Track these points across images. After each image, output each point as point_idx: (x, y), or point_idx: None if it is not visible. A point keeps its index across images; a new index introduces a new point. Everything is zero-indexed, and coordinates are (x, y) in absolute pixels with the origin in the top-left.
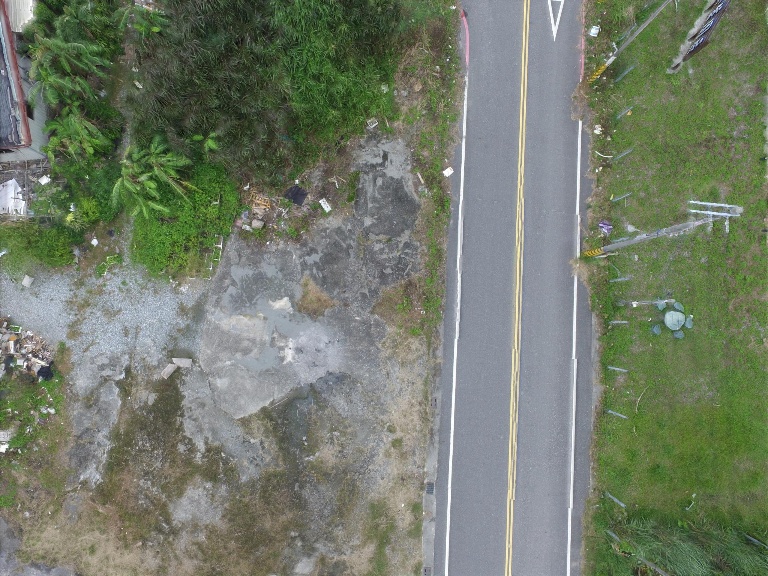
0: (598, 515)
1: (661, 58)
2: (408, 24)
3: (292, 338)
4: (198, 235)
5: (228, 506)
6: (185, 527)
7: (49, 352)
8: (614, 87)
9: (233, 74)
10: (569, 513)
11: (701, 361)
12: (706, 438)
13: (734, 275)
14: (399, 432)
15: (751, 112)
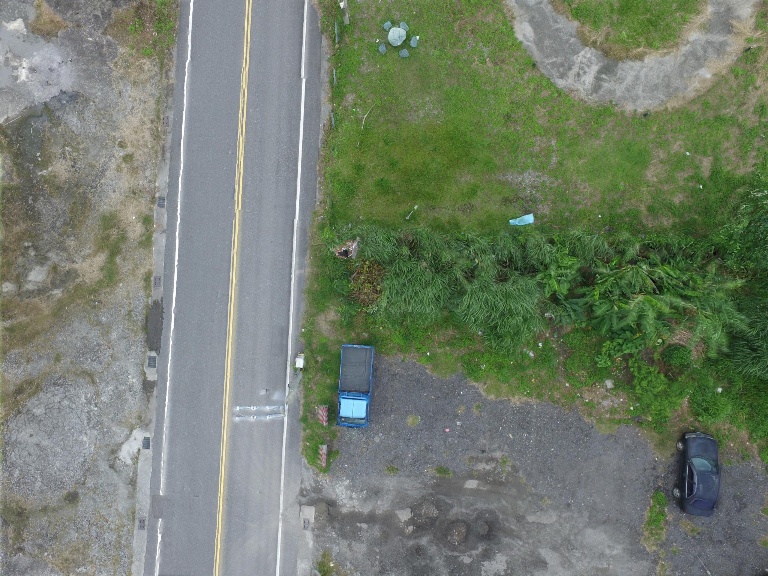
0: (321, 224)
1: None
2: None
3: (26, 58)
4: None
5: None
6: None
7: None
8: None
9: None
10: (295, 224)
11: (426, 80)
12: (429, 153)
13: None
14: (130, 148)
15: None
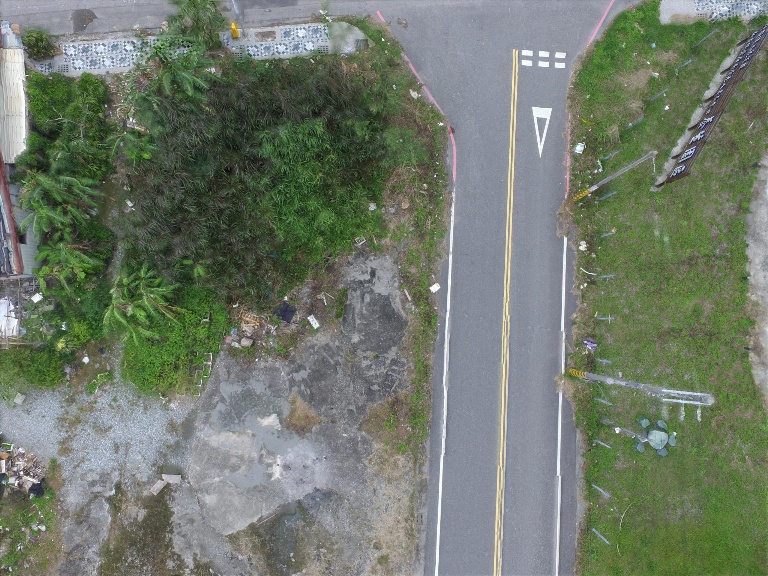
0: None
1: (645, 175)
2: (396, 144)
3: (280, 455)
4: (188, 354)
5: None
6: None
7: (40, 469)
8: (599, 204)
9: (222, 205)
10: None
11: (684, 478)
12: (689, 555)
13: (717, 392)
14: (385, 549)
15: (734, 230)
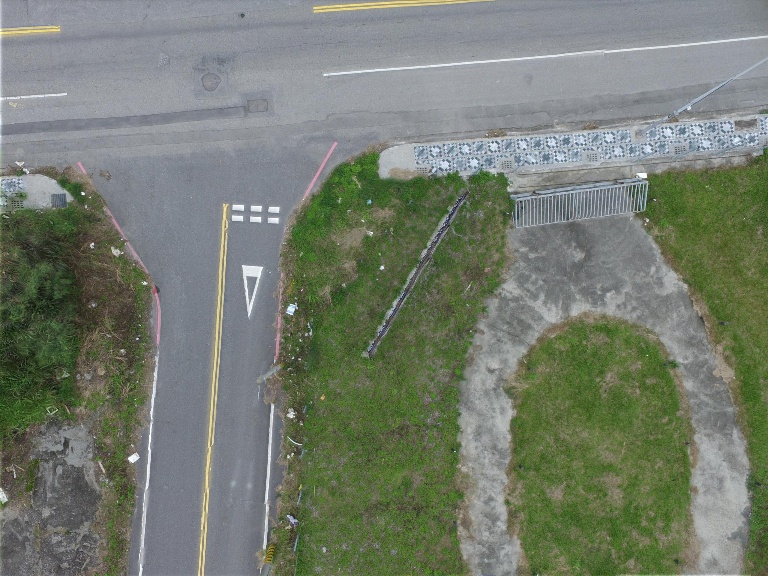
0: None
1: (357, 339)
2: (87, 309)
3: None
4: None
5: None
6: None
7: None
8: (307, 370)
9: None
10: None
11: None
12: None
13: (423, 568)
14: None
15: (446, 398)
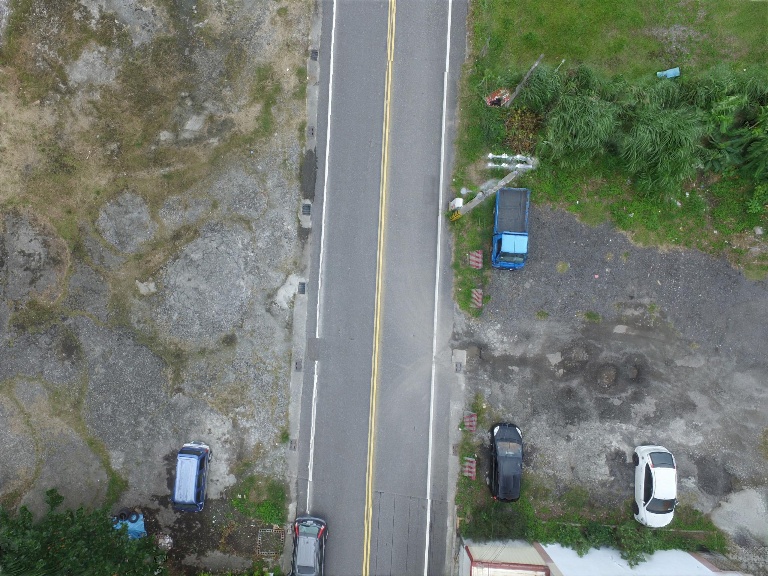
0: (472, 76)
1: None
2: None
3: None
4: None
5: (121, 68)
6: (81, 87)
7: None
8: None
9: None
10: (445, 76)
11: None
12: (576, 9)
13: None
14: (284, 1)
15: None
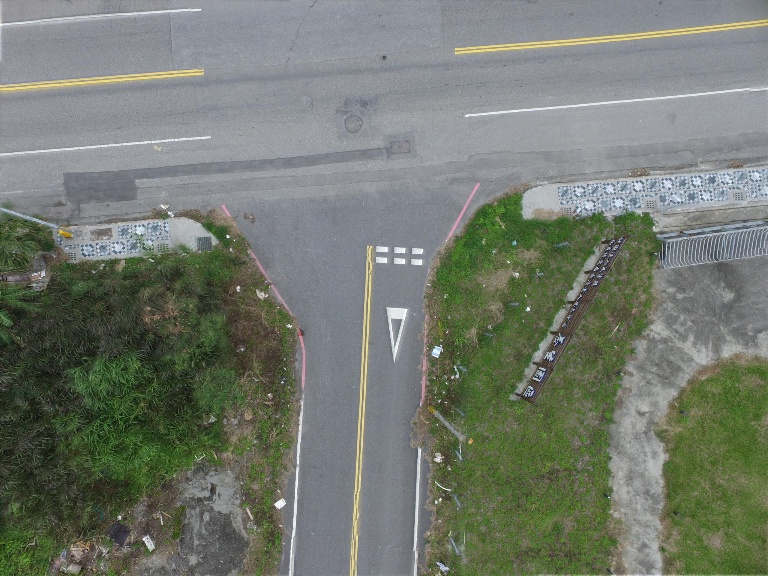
0: None
1: (504, 382)
2: (236, 354)
3: None
4: None
5: None
6: None
7: None
8: (455, 414)
9: (31, 444)
10: None
11: None
12: None
13: None
14: None
15: (596, 442)
